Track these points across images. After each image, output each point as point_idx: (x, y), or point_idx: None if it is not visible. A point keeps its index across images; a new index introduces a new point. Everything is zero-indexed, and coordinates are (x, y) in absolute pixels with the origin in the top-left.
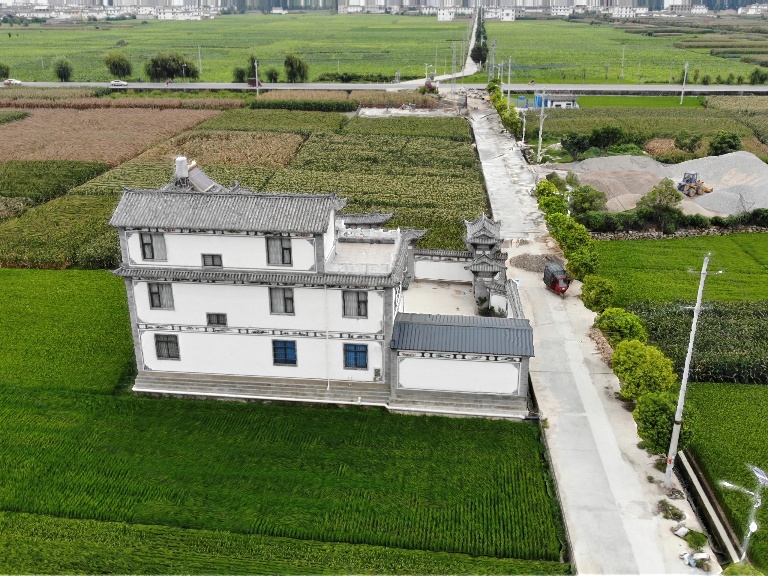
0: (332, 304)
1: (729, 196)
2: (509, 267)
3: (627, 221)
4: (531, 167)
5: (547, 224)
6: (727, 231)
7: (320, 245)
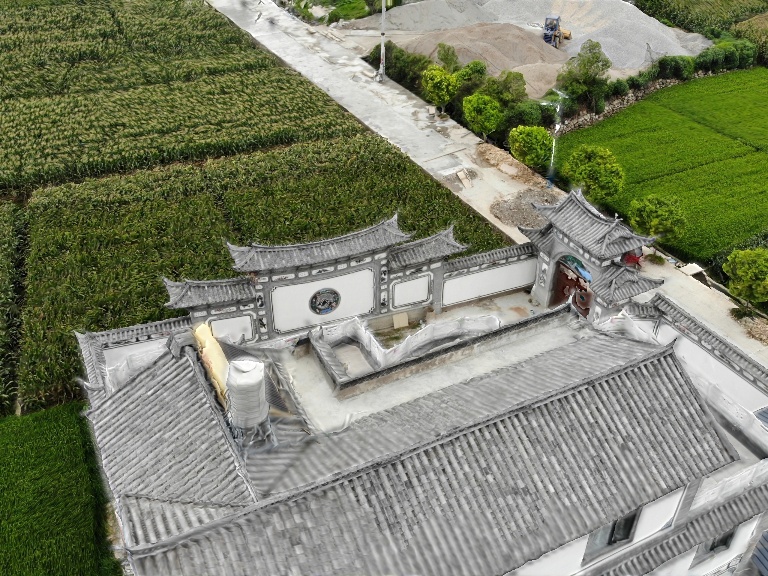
0: (680, 560)
1: (609, 43)
2: (508, 229)
3: (562, 109)
4: (323, 30)
5: (519, 147)
6: (640, 93)
7: (698, 479)
